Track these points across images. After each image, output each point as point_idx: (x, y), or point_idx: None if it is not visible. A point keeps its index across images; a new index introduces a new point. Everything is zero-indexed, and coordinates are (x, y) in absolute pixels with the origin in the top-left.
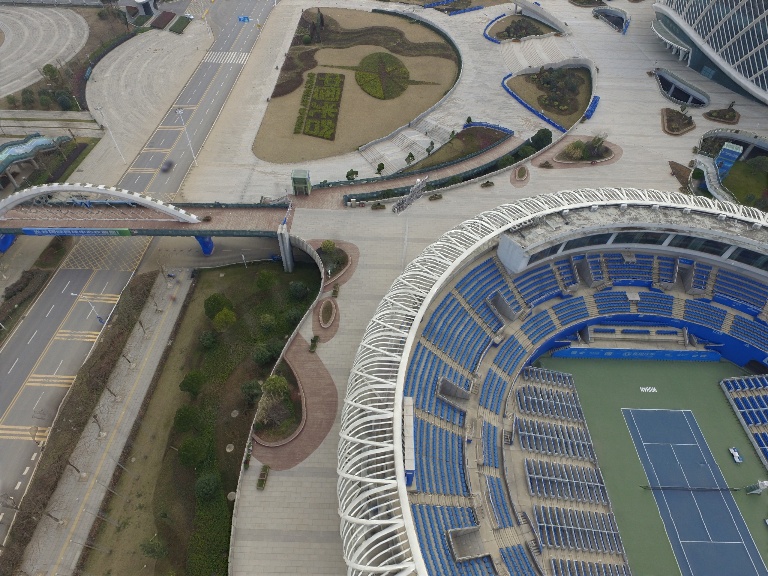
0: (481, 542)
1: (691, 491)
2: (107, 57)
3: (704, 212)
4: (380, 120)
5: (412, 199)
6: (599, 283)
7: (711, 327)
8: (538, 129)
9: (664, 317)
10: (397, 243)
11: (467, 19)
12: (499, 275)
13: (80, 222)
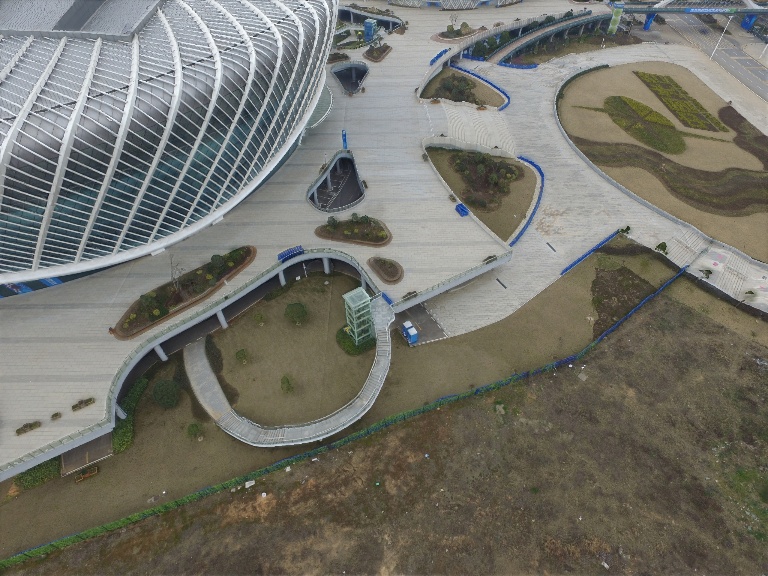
0: None
1: None
2: None
3: None
4: (608, 81)
5: None
6: None
7: None
8: (478, 69)
9: None
10: (555, 5)
11: (582, 222)
12: None
13: (708, 7)
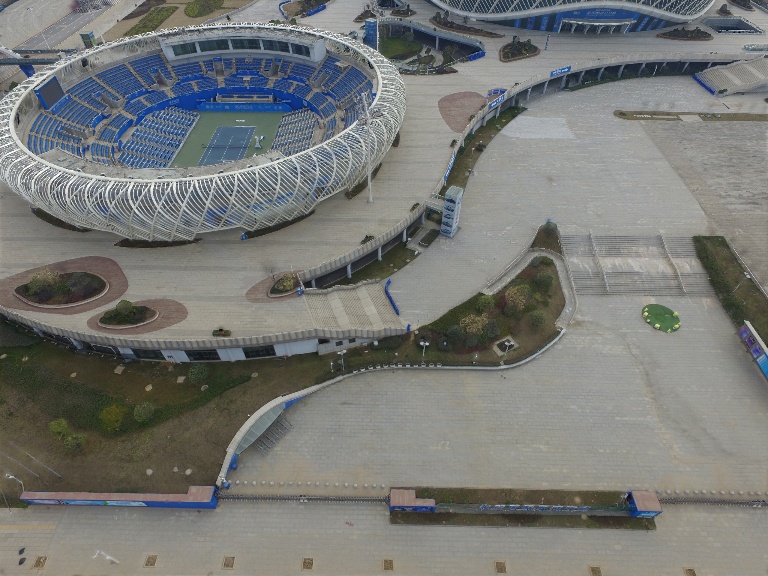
0: (86, 141)
1: (227, 148)
2: (18, 2)
3: (282, 29)
4: None
5: (89, 7)
6: (228, 72)
7: (281, 90)
8: None
9: (259, 87)
10: None
11: None
12: (162, 63)
13: None
